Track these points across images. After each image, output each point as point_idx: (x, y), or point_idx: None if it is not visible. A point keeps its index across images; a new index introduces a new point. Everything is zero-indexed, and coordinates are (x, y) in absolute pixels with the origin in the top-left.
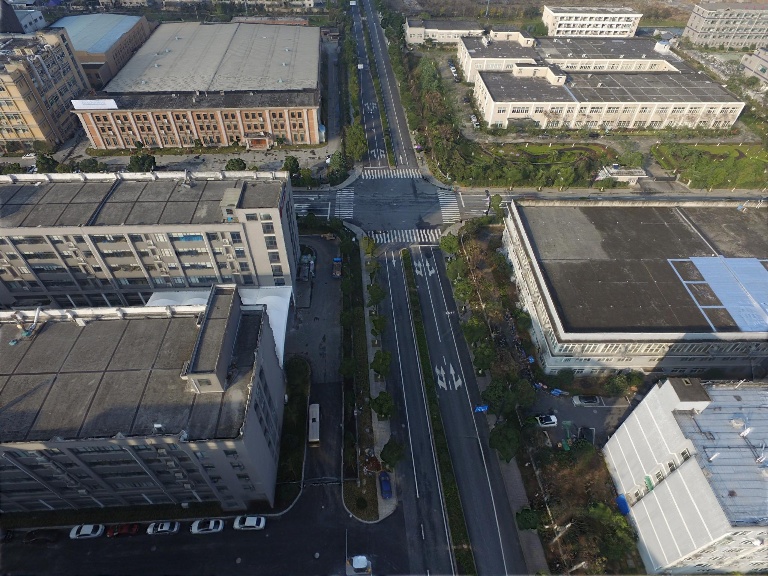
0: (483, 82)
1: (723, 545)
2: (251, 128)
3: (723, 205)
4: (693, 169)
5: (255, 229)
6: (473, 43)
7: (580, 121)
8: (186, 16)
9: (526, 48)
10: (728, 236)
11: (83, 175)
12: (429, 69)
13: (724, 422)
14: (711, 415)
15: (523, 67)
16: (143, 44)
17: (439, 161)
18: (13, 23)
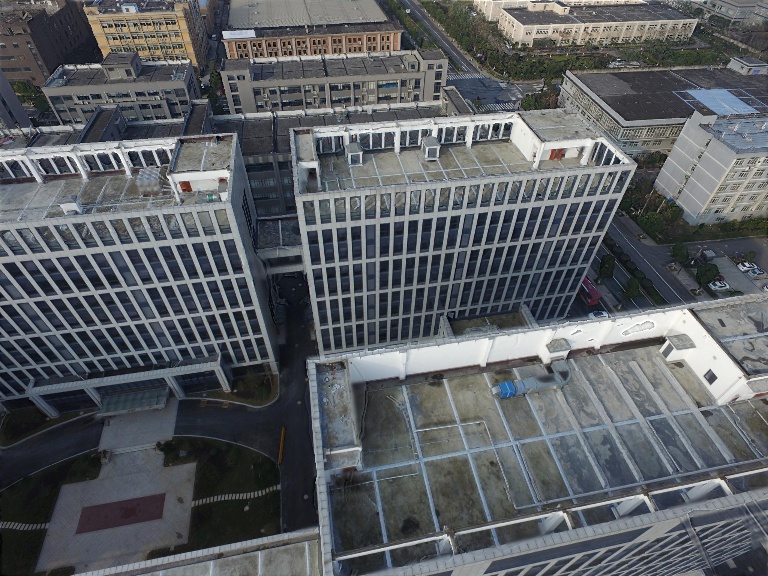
0: (510, 15)
1: (731, 179)
2: (351, 51)
3: (698, 68)
4: (670, 61)
5: (431, 76)
6: None
7: (584, 39)
8: None
9: None
10: (705, 81)
11: (300, 57)
12: (462, 10)
13: (725, 128)
14: (718, 127)
15: (536, 3)
16: (230, 1)
17: (496, 65)
18: None
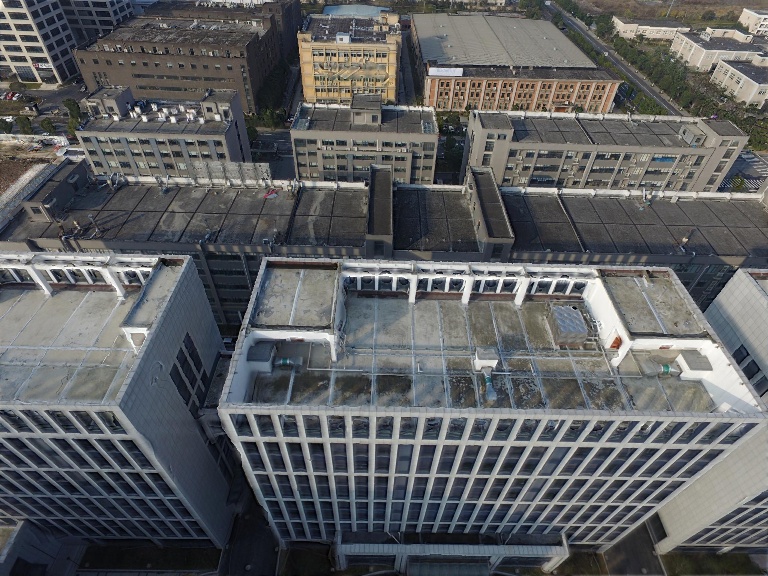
0: (735, 69)
1: None
2: (559, 98)
3: None
4: None
5: (719, 154)
6: (693, 38)
7: None
8: (416, 9)
9: (745, 43)
10: None
11: (551, 113)
12: None
13: None
14: None
15: (766, 57)
16: (416, 30)
17: None
18: (299, 9)
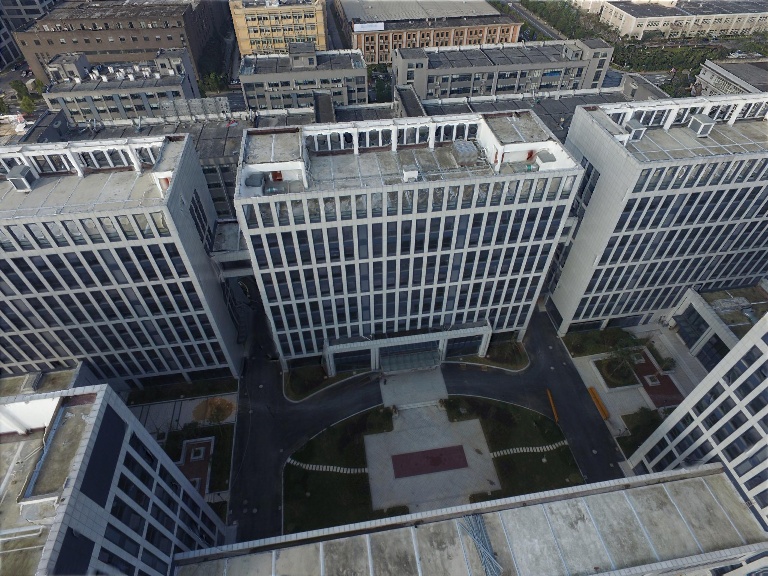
0: (617, 7)
1: None
2: (471, 43)
3: None
4: None
5: (594, 65)
6: None
7: (693, 31)
8: None
9: None
10: None
11: (460, 47)
12: (564, 4)
13: None
14: None
15: None
16: None
17: (616, 56)
18: None
